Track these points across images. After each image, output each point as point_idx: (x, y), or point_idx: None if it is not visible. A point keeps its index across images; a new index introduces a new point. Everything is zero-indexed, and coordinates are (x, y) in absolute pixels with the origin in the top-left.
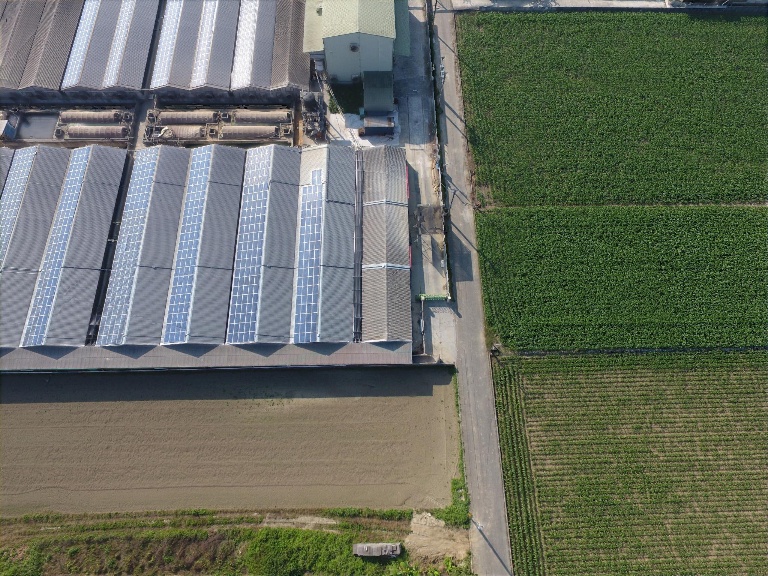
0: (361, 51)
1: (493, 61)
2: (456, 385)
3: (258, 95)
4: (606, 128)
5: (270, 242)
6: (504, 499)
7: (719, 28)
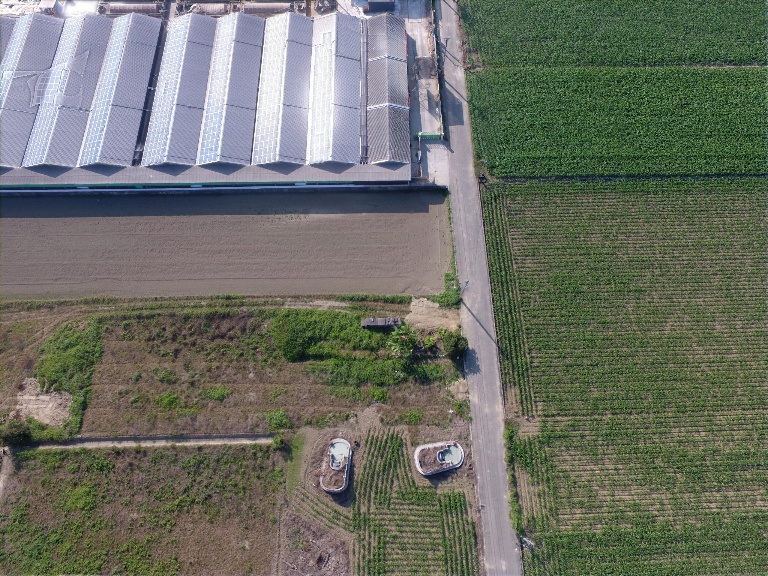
0: None
1: None
2: (449, 203)
3: None
4: (582, 6)
5: (288, 87)
6: (489, 287)
7: None
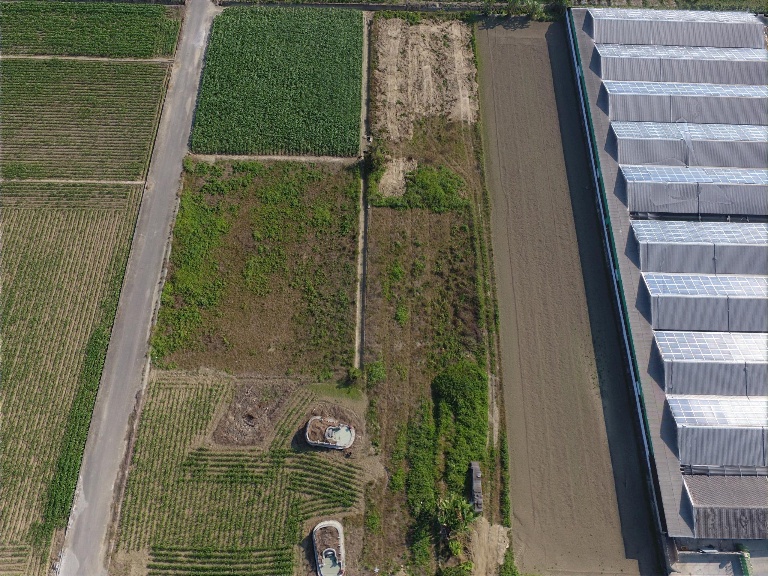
0: None
1: None
2: None
3: None
4: None
5: None
6: None
7: None
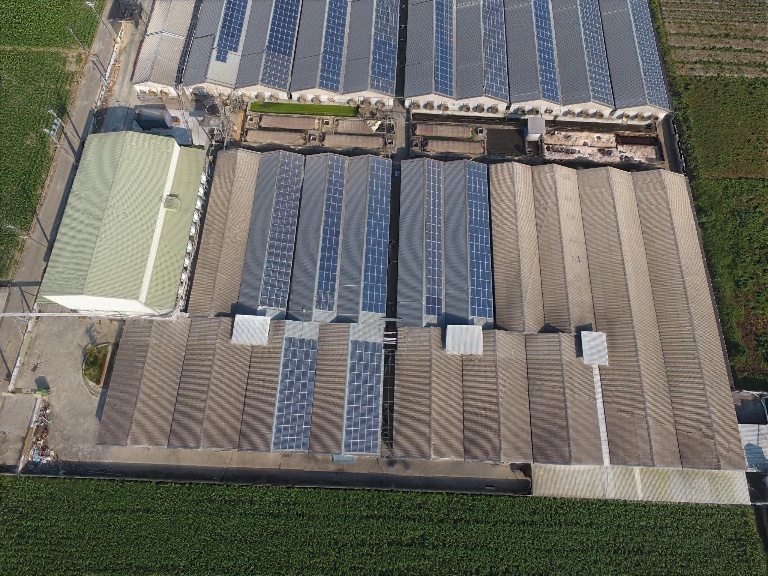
0: None
1: None
2: None
3: None
4: None
5: (269, 7)
6: None
7: None
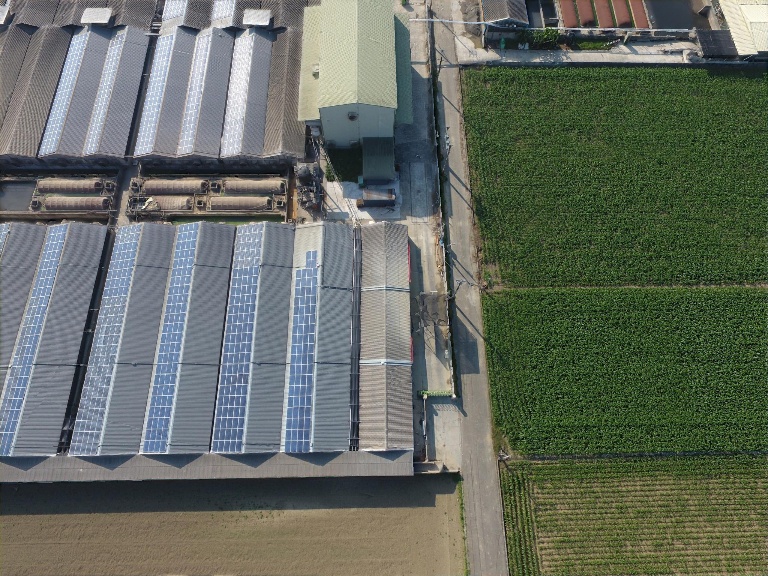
0: (360, 119)
1: (501, 122)
2: (461, 495)
3: (250, 162)
4: (621, 199)
5: (260, 335)
6: None
7: (740, 86)
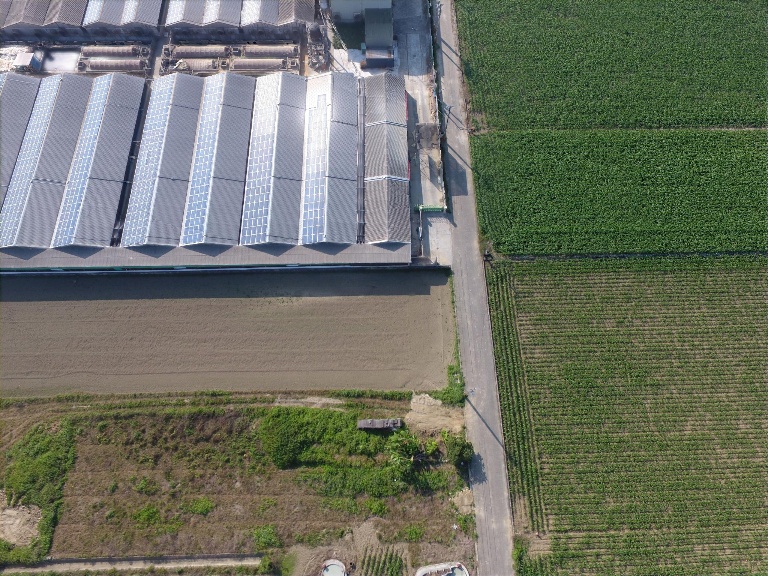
0: None
1: (487, 2)
2: (452, 285)
3: (266, 31)
4: (593, 61)
5: (279, 157)
6: (496, 382)
7: None
